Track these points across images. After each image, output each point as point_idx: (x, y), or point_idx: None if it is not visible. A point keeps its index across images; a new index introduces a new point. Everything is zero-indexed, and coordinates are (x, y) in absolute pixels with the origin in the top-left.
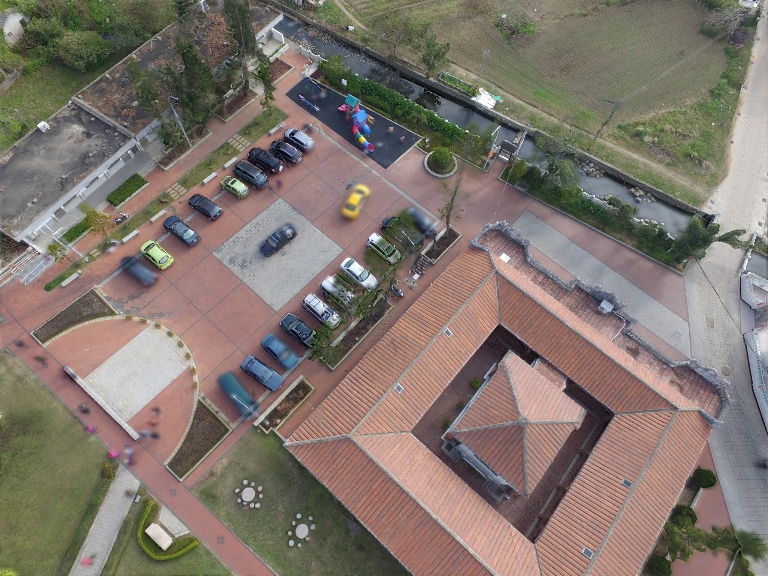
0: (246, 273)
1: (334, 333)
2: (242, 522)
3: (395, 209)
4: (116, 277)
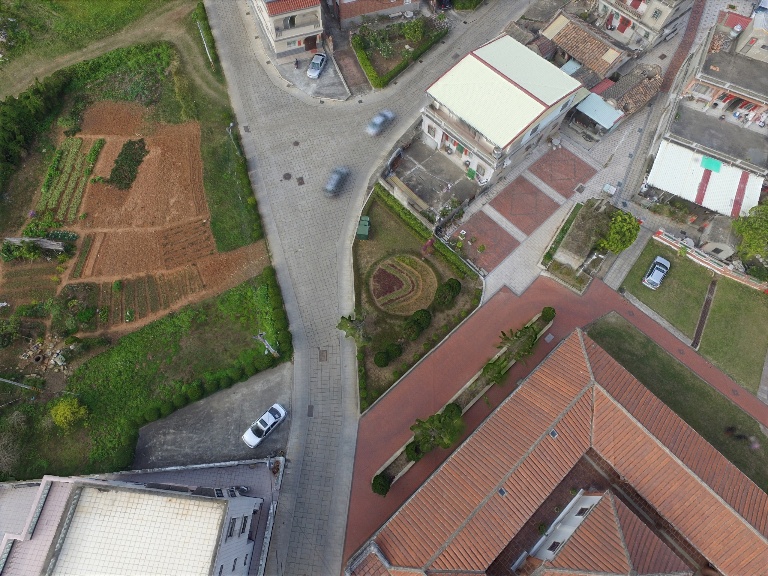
0: None
1: None
2: None
3: None
4: None
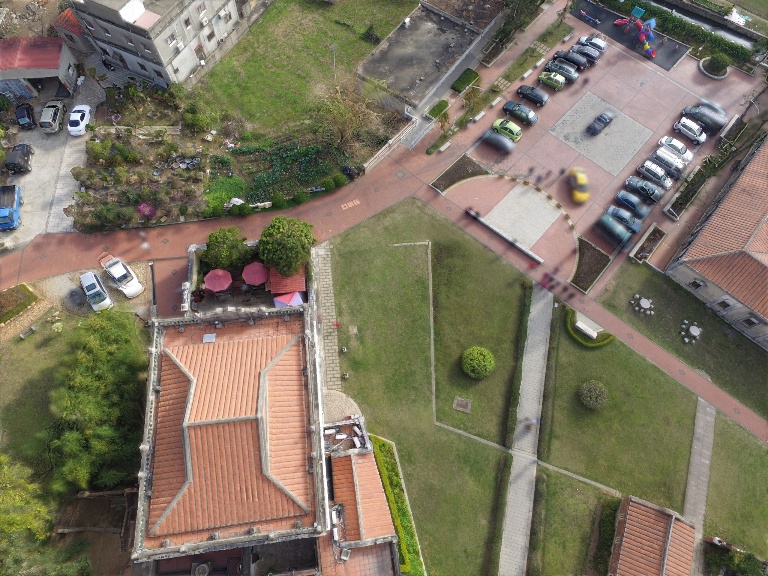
0: (581, 147)
1: (667, 194)
2: (642, 324)
3: (686, 103)
4: (478, 147)
